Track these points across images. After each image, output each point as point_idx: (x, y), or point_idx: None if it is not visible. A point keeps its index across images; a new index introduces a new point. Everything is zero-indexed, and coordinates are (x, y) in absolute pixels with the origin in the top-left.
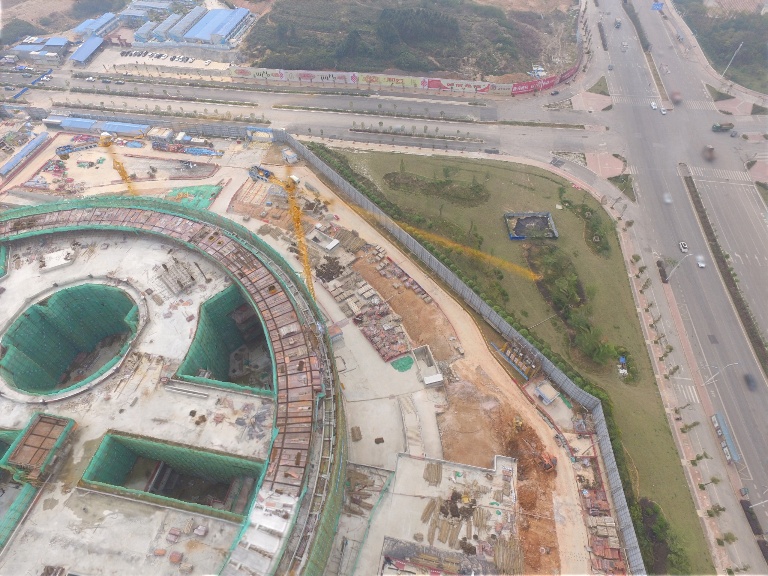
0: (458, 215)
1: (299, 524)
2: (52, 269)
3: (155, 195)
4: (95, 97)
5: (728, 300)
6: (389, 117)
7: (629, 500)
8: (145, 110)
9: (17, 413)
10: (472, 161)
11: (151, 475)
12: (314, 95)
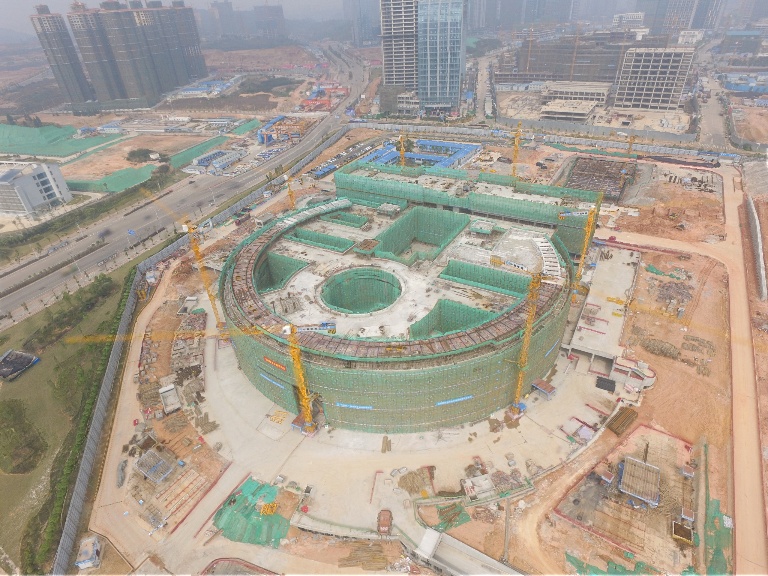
0: (40, 394)
1: None
2: None
3: (303, 524)
4: None
5: None
6: None
7: None
8: None
9: (386, 266)
10: None
11: None
12: None
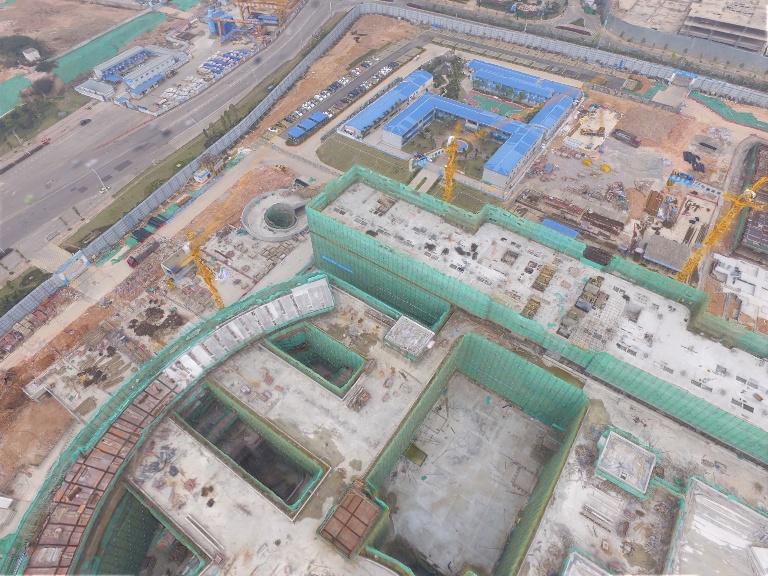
0: None
1: None
2: None
3: None
4: None
5: None
6: None
7: None
8: None
9: None
10: None
11: (294, 497)
12: None
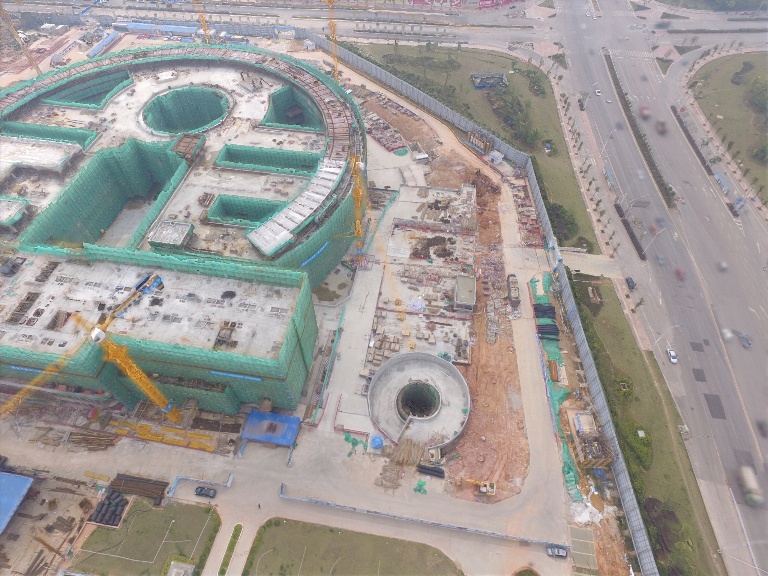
0: (438, 77)
1: (346, 179)
2: (164, 81)
3: None
4: (147, 12)
5: (624, 118)
6: (384, 23)
7: (543, 196)
8: (190, 20)
9: None
10: (448, 48)
11: None
12: (323, 10)
